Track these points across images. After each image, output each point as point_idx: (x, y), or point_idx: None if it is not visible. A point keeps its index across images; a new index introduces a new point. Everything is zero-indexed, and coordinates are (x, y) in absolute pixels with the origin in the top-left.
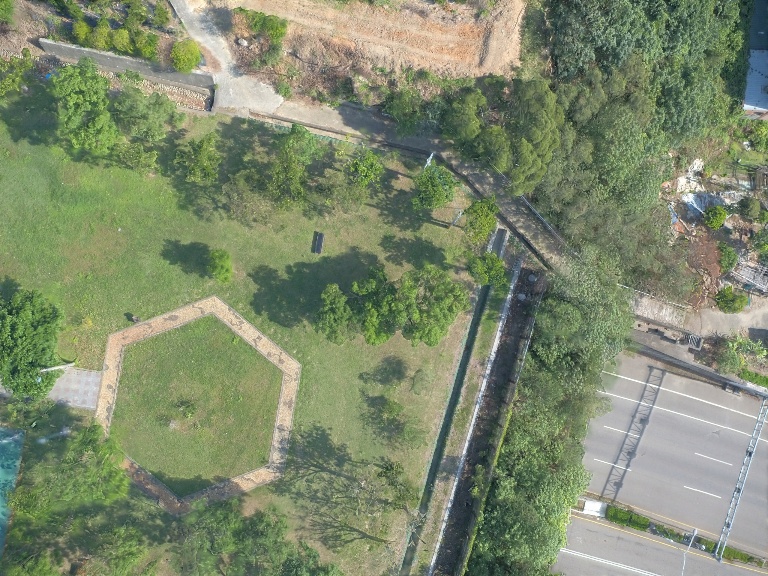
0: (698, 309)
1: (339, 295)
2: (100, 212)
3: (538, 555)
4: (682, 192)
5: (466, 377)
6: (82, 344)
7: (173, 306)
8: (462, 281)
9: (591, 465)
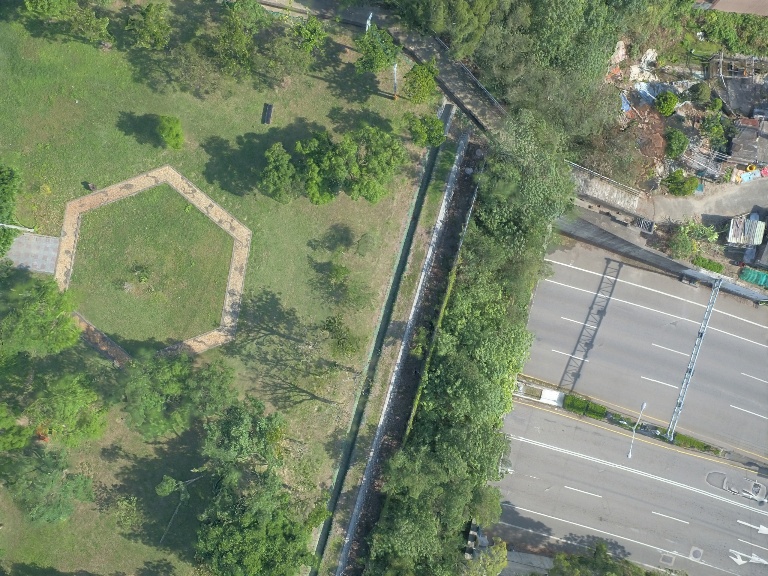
0: (651, 195)
1: (283, 153)
2: (58, 85)
3: (479, 410)
4: (635, 80)
5: (412, 245)
6: (41, 212)
7: (128, 175)
8: (408, 151)
9: (549, 356)
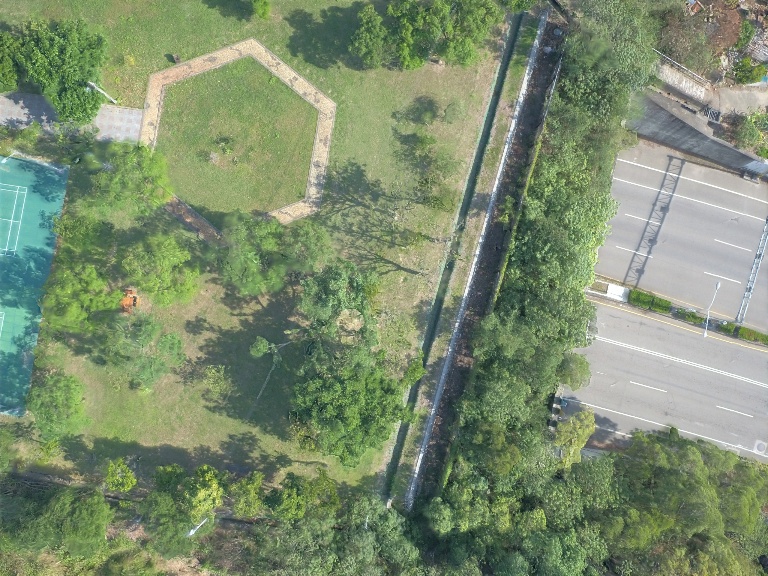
0: (716, 88)
1: (375, 15)
2: None
3: (569, 274)
4: None
5: (495, 118)
6: (124, 84)
7: (211, 48)
8: None
9: (613, 252)
